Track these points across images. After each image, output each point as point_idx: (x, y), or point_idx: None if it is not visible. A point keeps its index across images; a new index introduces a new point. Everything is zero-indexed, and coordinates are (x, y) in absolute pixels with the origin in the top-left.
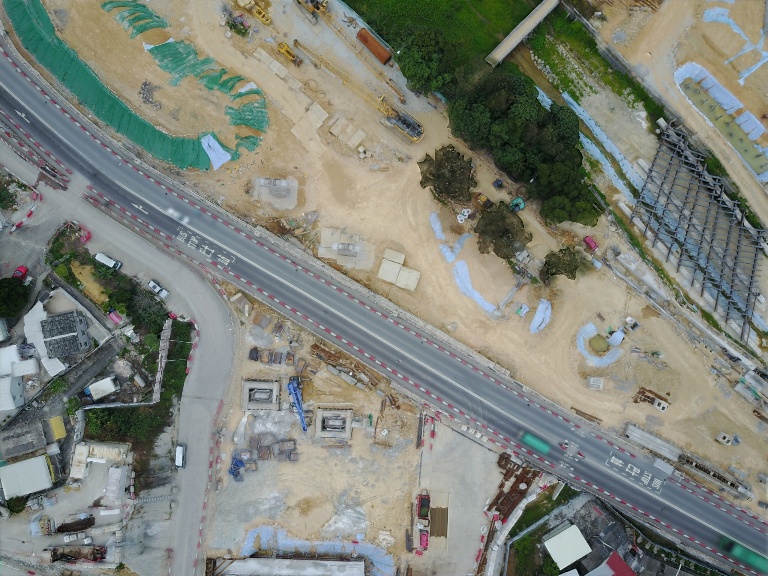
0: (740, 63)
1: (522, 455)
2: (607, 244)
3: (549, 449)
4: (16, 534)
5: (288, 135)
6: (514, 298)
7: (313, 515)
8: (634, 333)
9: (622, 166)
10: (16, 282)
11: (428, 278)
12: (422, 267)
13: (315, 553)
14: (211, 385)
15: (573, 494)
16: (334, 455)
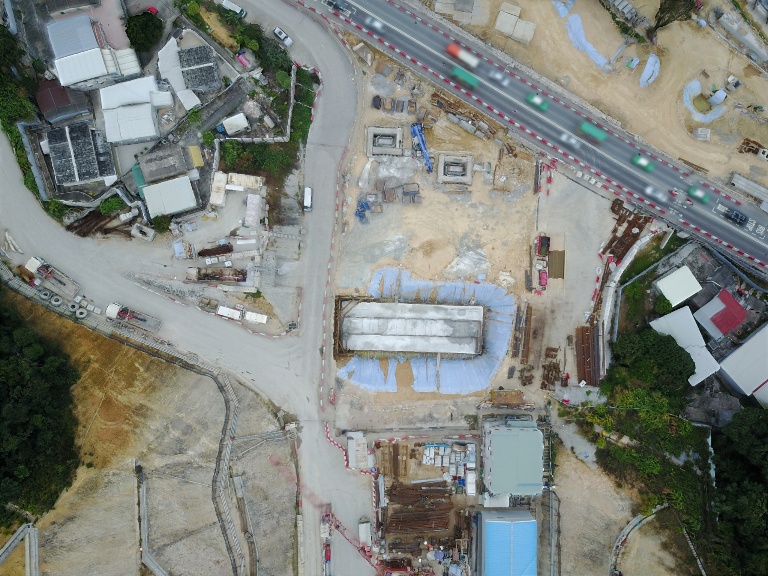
0: None
1: (634, 201)
2: (711, 5)
3: (659, 196)
4: (158, 259)
5: None
6: (624, 53)
7: (436, 257)
8: (736, 92)
9: None
10: (152, 14)
11: (542, 33)
12: (536, 22)
13: (434, 300)
14: (335, 133)
15: (680, 243)
16: (455, 201)
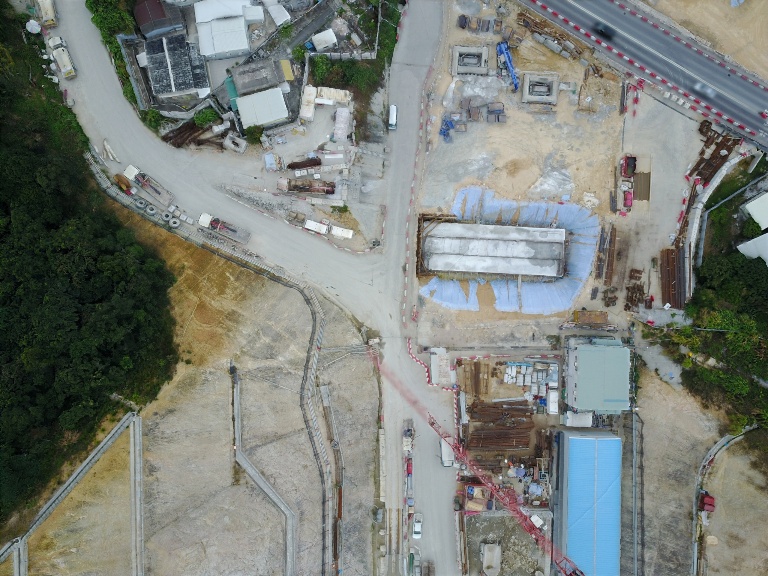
0: None
1: (723, 123)
2: None
3: (749, 118)
4: (248, 171)
5: None
6: None
7: (520, 177)
8: None
9: None
10: None
11: None
12: None
13: (516, 223)
14: (420, 52)
15: None
16: (539, 121)
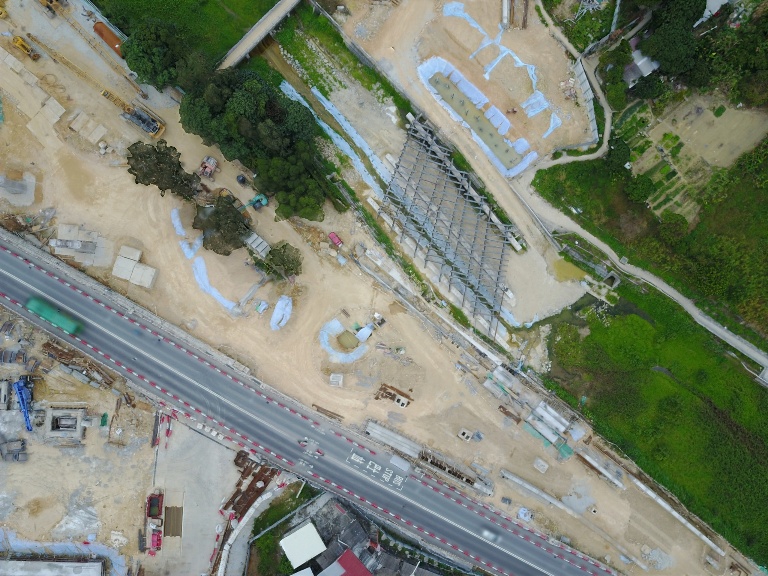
0: (482, 57)
1: (260, 453)
2: (353, 240)
3: (288, 447)
4: None
5: (24, 130)
6: (255, 295)
7: (43, 516)
8: (382, 329)
9: (372, 161)
10: None
11: (167, 275)
12: (161, 264)
13: (53, 554)
14: None
15: (317, 492)
16: (67, 455)
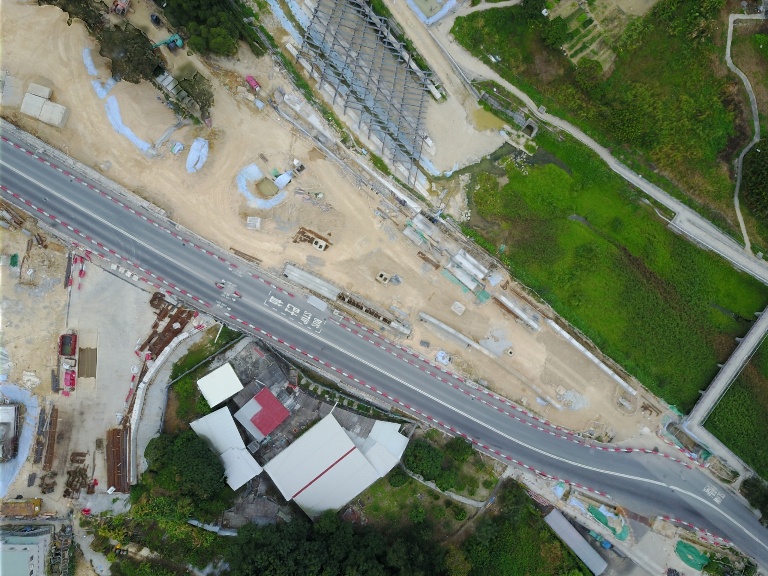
0: None
1: (176, 295)
2: (271, 85)
3: (205, 289)
4: None
5: None
6: (171, 137)
7: None
8: (301, 176)
9: (291, 7)
10: None
11: (79, 115)
12: (72, 104)
13: None
14: None
15: (236, 337)
16: None
